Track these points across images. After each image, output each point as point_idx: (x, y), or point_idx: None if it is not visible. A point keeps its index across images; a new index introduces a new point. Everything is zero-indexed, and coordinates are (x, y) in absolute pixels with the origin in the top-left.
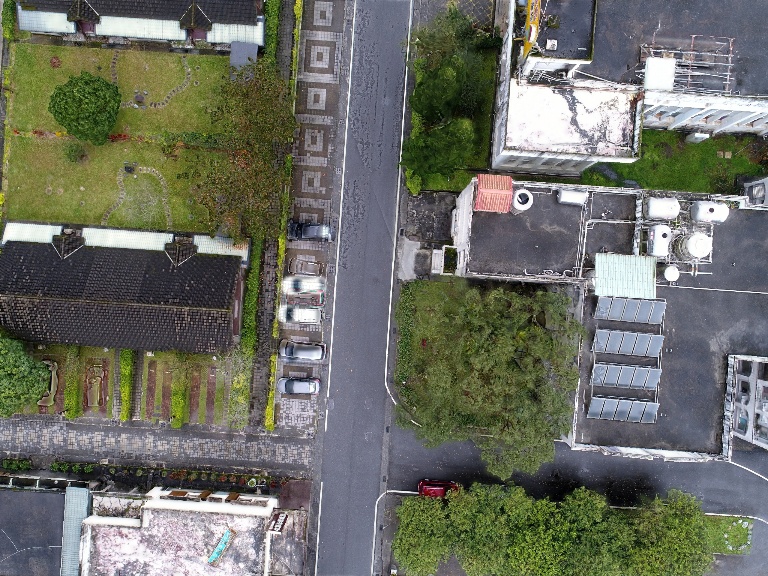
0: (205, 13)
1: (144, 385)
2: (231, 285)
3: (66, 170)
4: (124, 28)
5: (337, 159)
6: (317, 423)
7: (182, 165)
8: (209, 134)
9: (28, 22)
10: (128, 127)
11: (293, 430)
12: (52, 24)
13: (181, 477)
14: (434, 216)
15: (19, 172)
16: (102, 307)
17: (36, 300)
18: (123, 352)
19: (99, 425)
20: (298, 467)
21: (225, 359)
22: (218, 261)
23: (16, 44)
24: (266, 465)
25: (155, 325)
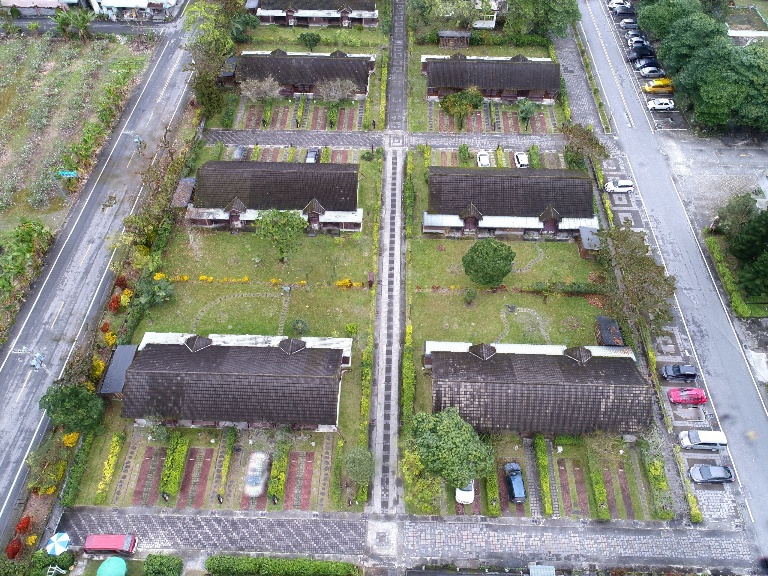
0: (558, 211)
1: (557, 482)
2: (638, 372)
3: (458, 312)
4: (499, 222)
5: (670, 300)
6: (741, 514)
7: (551, 306)
8: (572, 282)
9: (431, 221)
10: (503, 283)
11: (719, 523)
12: (448, 222)
13: (625, 574)
14: (767, 334)
15: (420, 315)
16: (536, 388)
17: (478, 384)
18: (539, 444)
19: (519, 525)
20: (740, 563)
21: (647, 438)
22: (615, 360)
23: (411, 239)
24: (705, 562)
25: (582, 405)
